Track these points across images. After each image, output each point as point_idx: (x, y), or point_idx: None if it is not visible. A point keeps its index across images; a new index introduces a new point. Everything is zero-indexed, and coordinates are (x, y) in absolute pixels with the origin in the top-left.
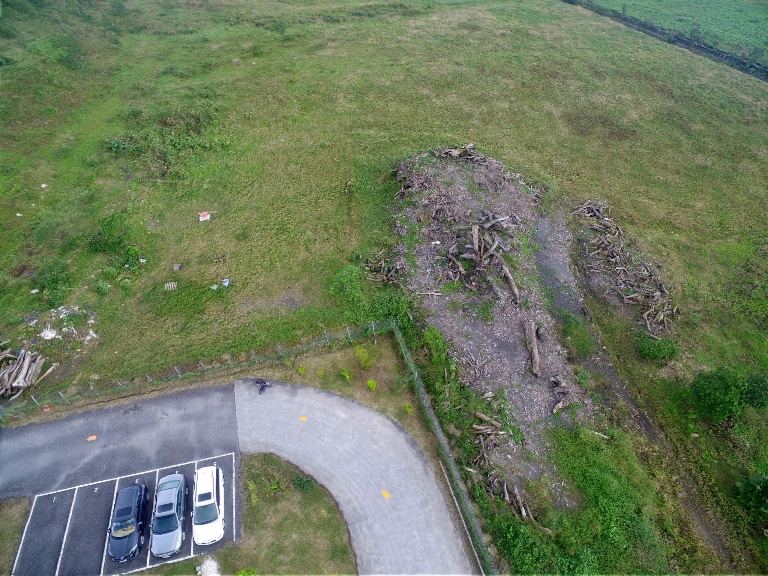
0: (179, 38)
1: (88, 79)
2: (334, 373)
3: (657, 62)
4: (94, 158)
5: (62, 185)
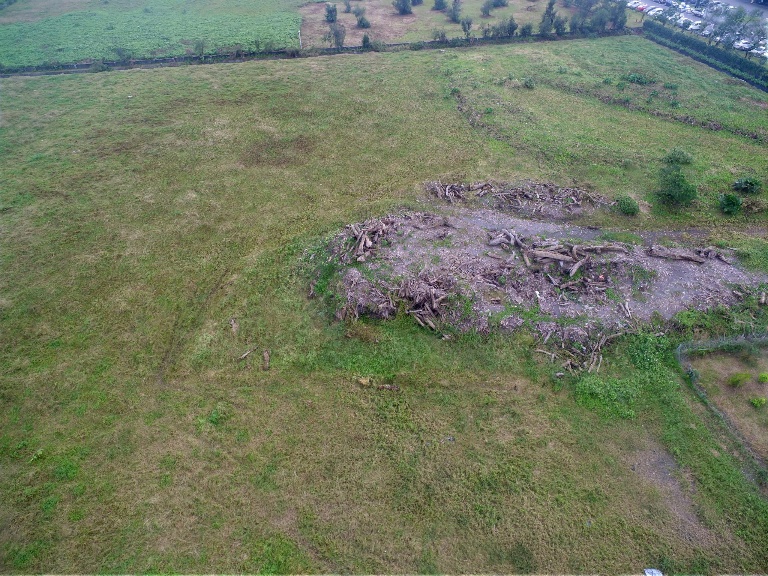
0: None
1: None
2: (759, 415)
3: (152, 88)
4: None
5: None
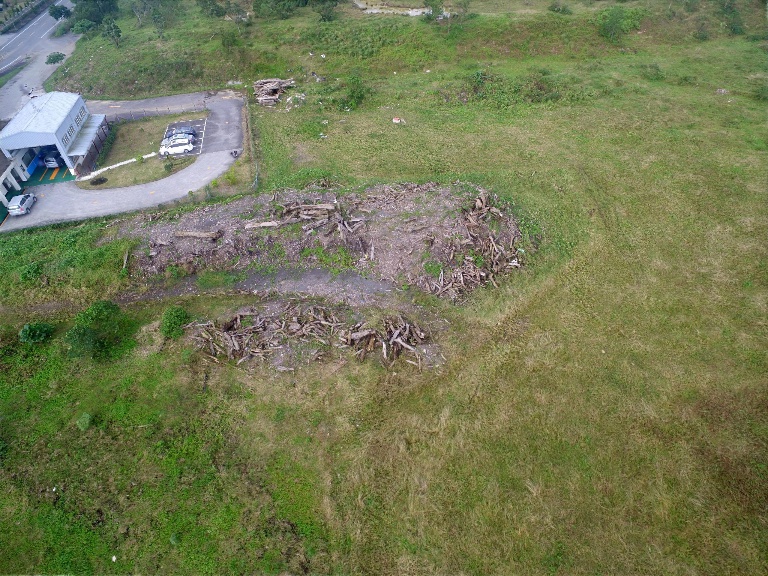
0: (762, 58)
1: (598, 46)
2: (234, 175)
3: None
4: (461, 73)
5: (430, 75)
